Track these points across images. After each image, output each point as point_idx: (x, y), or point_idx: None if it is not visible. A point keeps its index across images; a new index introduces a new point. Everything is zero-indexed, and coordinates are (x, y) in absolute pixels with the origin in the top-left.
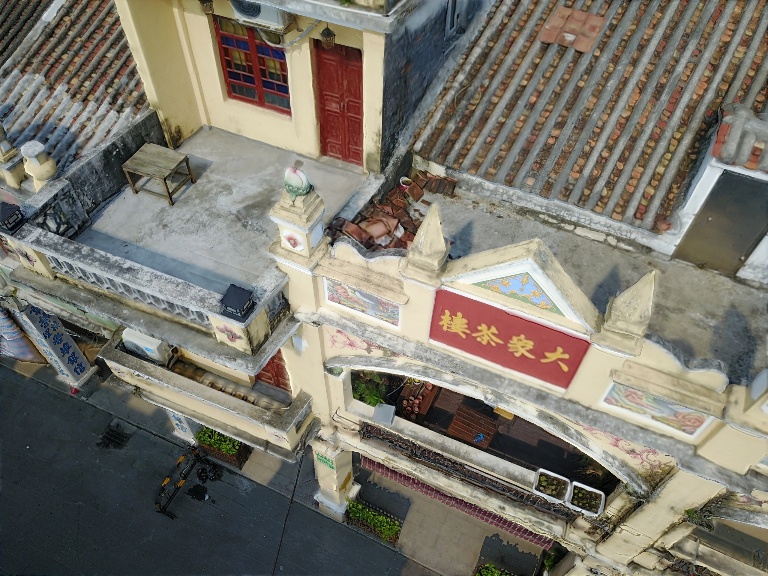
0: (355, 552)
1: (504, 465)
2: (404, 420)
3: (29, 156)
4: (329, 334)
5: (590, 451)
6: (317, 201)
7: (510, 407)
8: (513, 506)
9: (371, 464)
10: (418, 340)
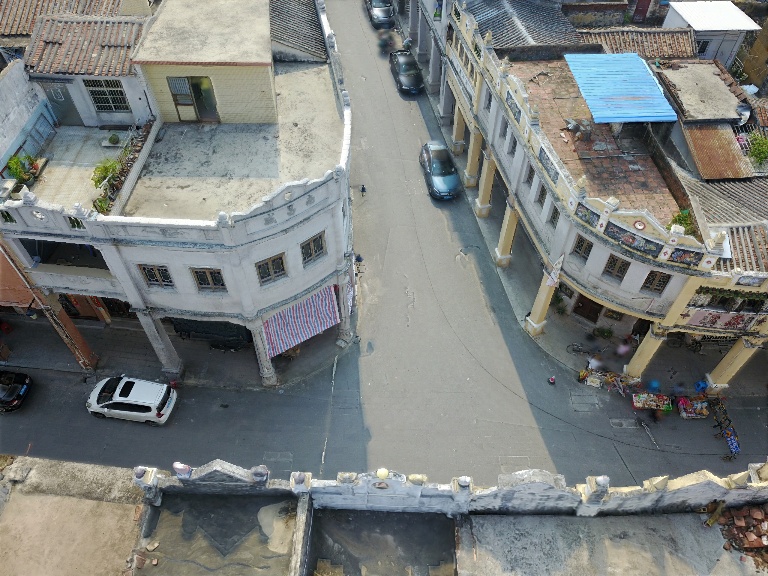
0: None
1: None
2: None
3: None
4: None
5: None
6: None
7: None
8: None
9: None
10: None
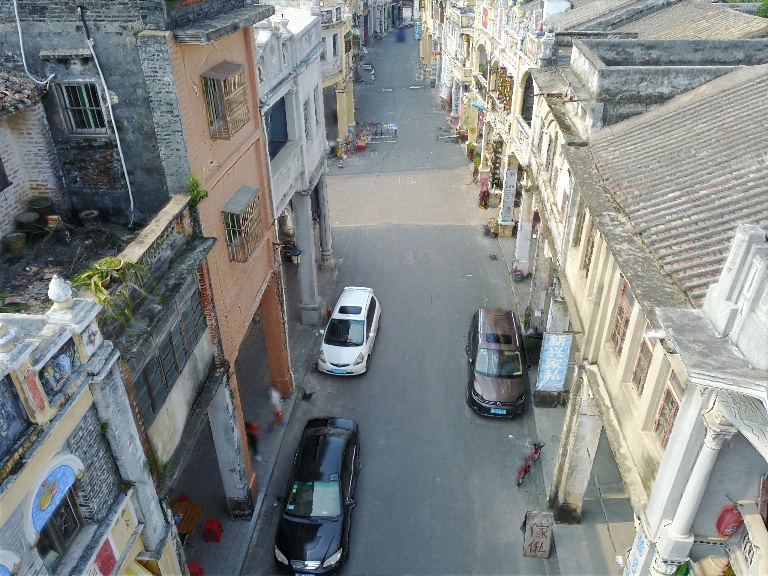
0: (461, 160)
1: (486, 81)
2: (481, 75)
3: None
4: (476, 35)
5: (485, 48)
6: None
7: None
8: (483, 100)
9: None
10: None
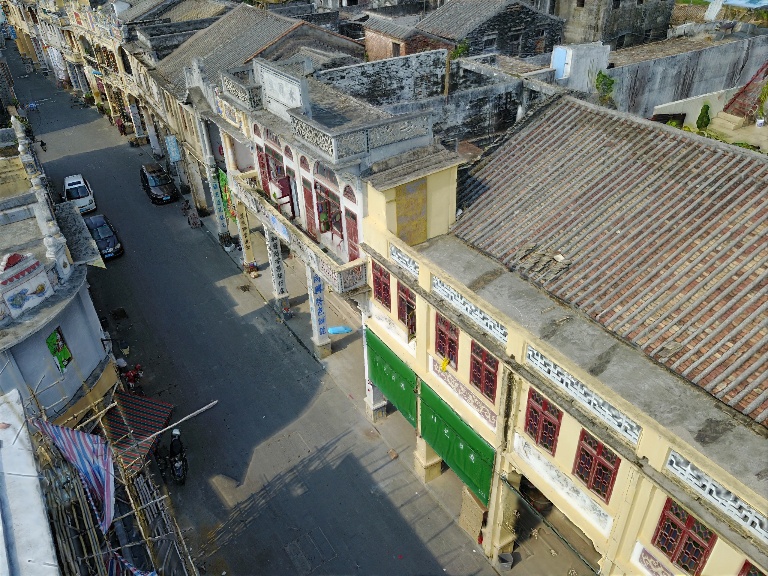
0: None
1: None
2: None
3: (56, 6)
4: None
5: None
6: (69, 3)
7: (81, 32)
8: None
9: (99, 87)
10: None
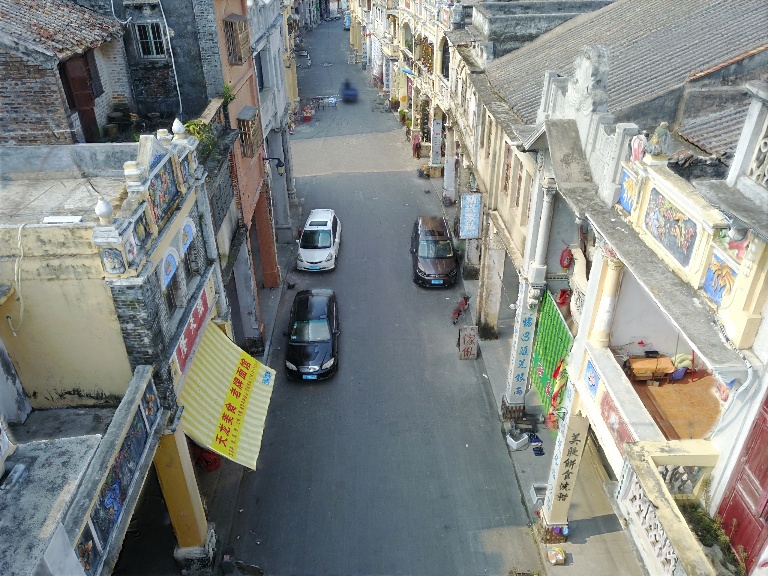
0: (395, 125)
1: None
2: None
3: None
4: None
5: None
6: None
7: None
8: None
9: None
10: (404, 7)
